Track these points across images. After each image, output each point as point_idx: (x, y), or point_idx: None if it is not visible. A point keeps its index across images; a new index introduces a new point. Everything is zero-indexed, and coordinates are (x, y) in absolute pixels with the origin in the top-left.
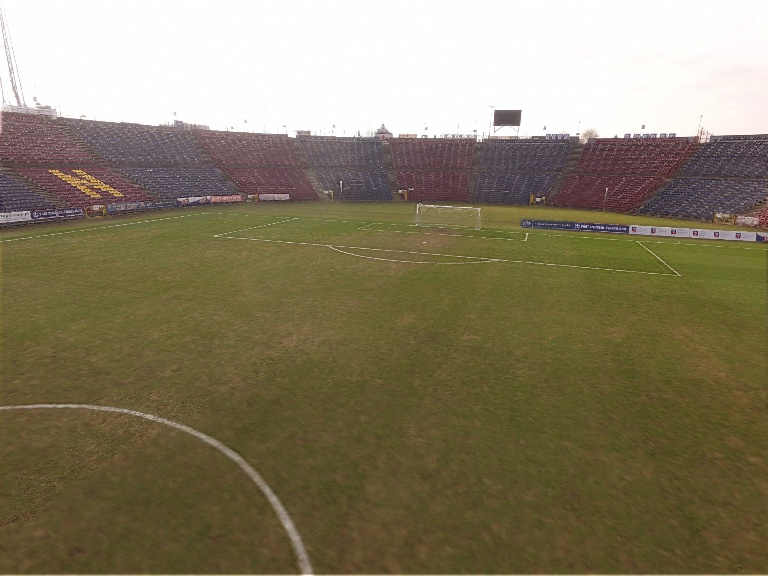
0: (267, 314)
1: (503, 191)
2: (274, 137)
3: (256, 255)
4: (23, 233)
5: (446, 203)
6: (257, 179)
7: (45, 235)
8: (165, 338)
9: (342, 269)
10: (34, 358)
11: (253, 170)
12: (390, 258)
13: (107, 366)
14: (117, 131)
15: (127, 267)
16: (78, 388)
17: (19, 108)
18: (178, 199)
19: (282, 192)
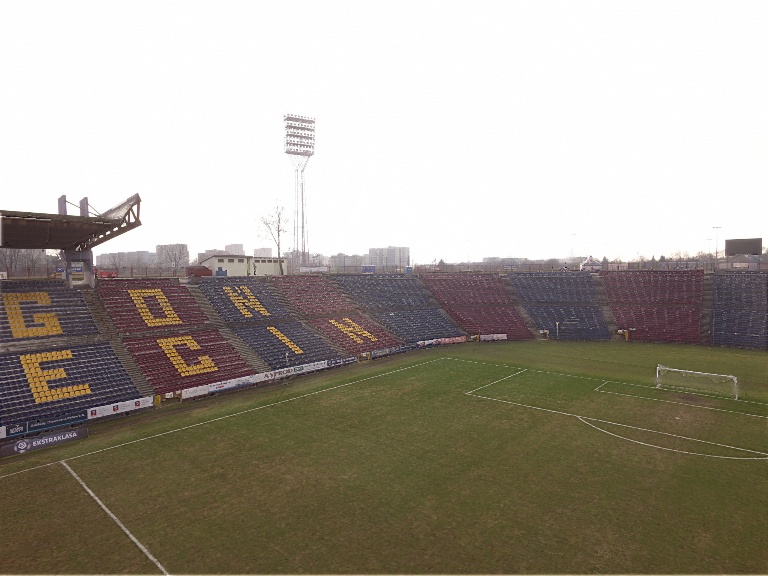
0: (567, 511)
1: (751, 335)
2: (486, 276)
3: (517, 425)
4: (327, 381)
5: (676, 345)
6: (475, 318)
7: (343, 385)
8: (500, 528)
9: (607, 455)
10: (423, 534)
11: (471, 309)
12: (649, 442)
13: (476, 553)
14: (367, 281)
15: (423, 433)
16: (470, 573)
17: (306, 268)
18: (417, 342)
19: (498, 331)
